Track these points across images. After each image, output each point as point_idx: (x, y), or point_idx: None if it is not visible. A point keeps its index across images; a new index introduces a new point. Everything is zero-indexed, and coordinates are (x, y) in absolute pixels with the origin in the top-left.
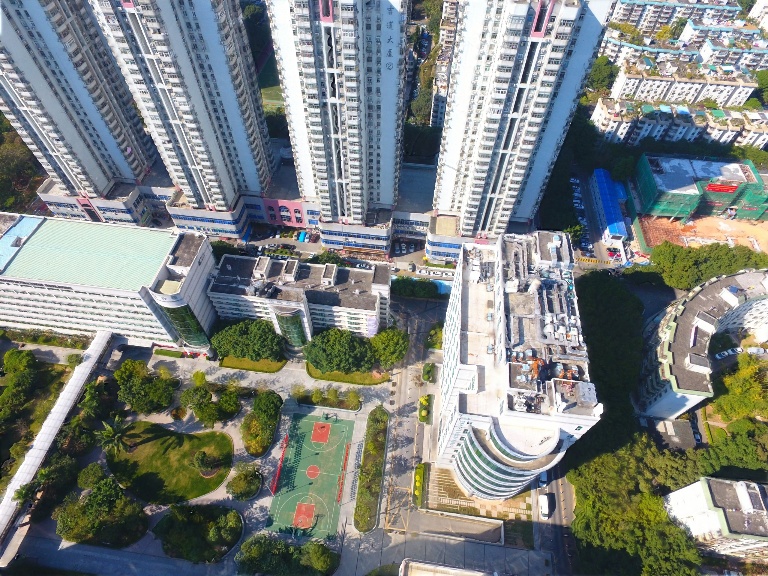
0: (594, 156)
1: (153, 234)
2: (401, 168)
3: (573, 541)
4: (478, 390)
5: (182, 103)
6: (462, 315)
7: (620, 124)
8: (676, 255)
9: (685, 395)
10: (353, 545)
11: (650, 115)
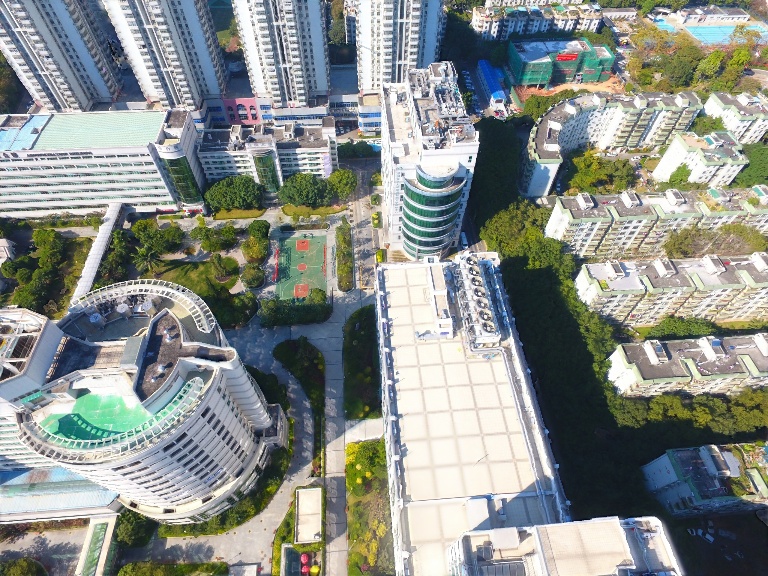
0: (477, 52)
1: (146, 114)
2: (329, 64)
3: None
4: (405, 155)
5: (154, 7)
6: (388, 122)
7: (491, 24)
8: (540, 102)
9: (546, 166)
10: (340, 301)
11: (511, 14)
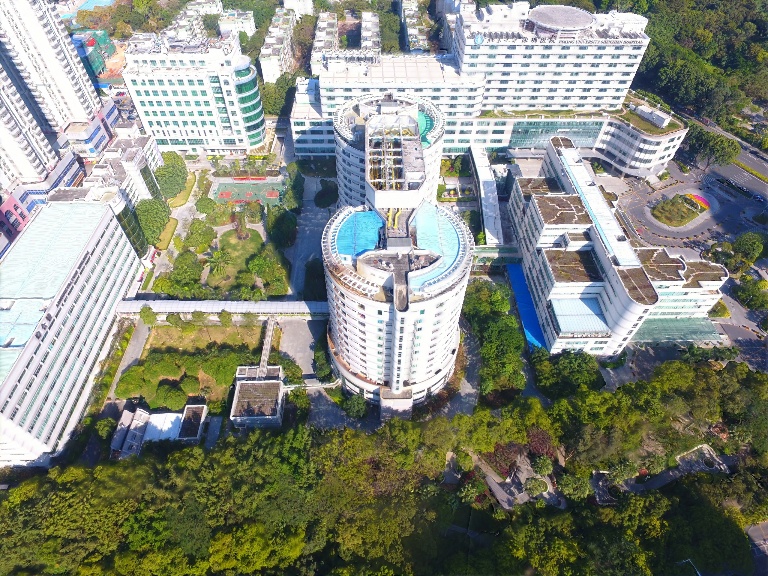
0: None
1: (39, 218)
2: None
3: (284, 118)
4: None
5: None
6: None
7: None
8: None
9: None
10: None
11: None
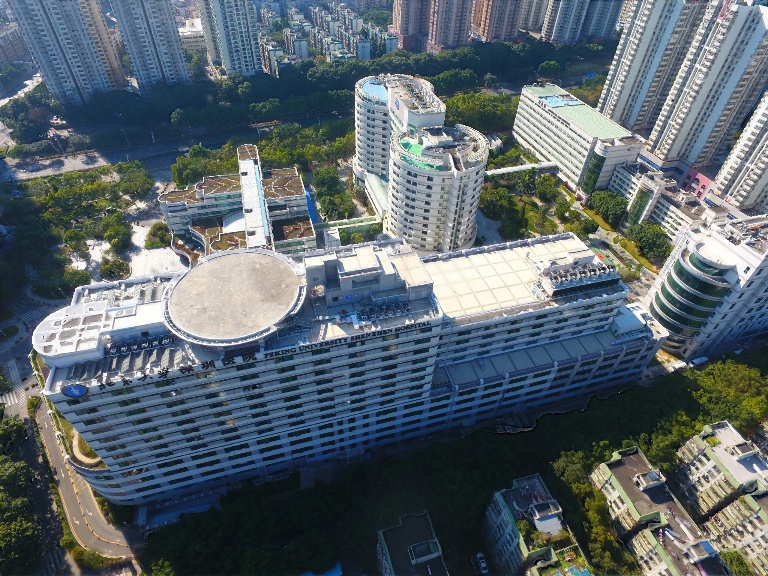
0: None
1: (621, 130)
2: None
3: None
4: None
5: (700, 78)
6: None
7: None
8: None
9: None
10: None
11: None
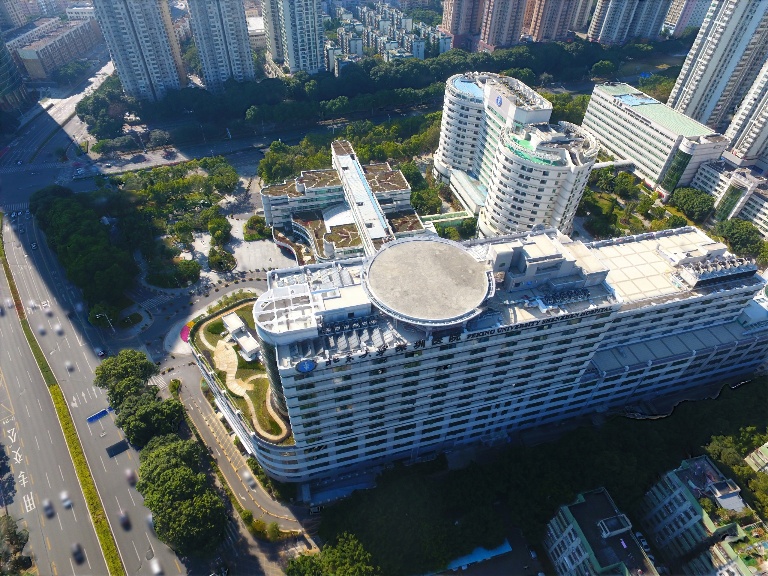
0: None
1: (704, 128)
2: None
3: None
4: None
5: None
6: None
7: None
8: None
9: None
10: None
11: None
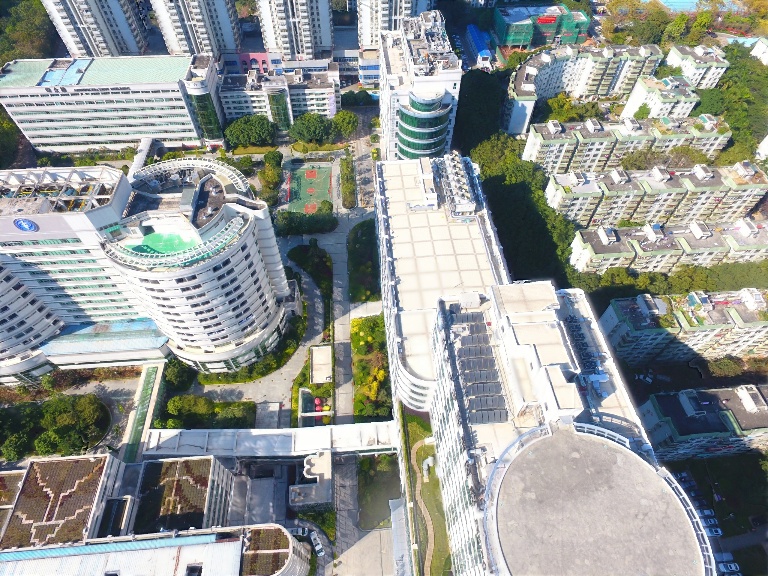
0: (466, 18)
1: (174, 58)
2: None
3: None
4: (400, 84)
5: None
6: (386, 60)
7: None
8: (521, 57)
9: (523, 103)
10: (344, 216)
11: None
